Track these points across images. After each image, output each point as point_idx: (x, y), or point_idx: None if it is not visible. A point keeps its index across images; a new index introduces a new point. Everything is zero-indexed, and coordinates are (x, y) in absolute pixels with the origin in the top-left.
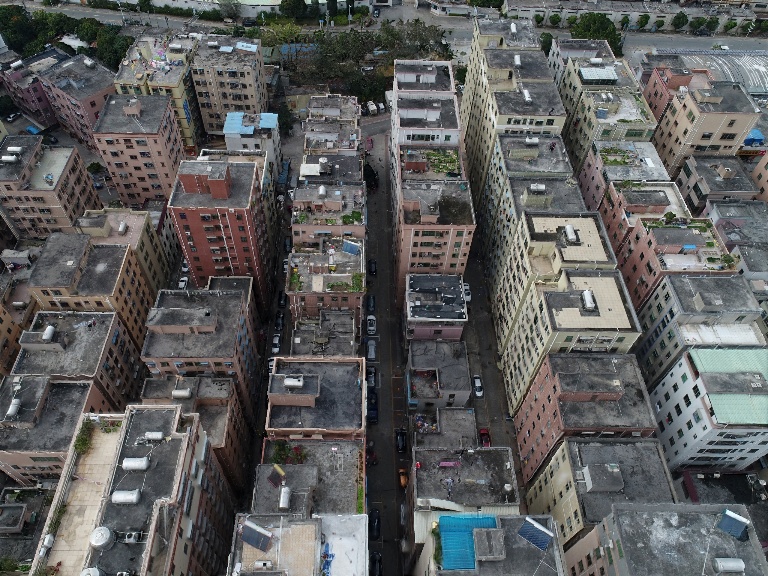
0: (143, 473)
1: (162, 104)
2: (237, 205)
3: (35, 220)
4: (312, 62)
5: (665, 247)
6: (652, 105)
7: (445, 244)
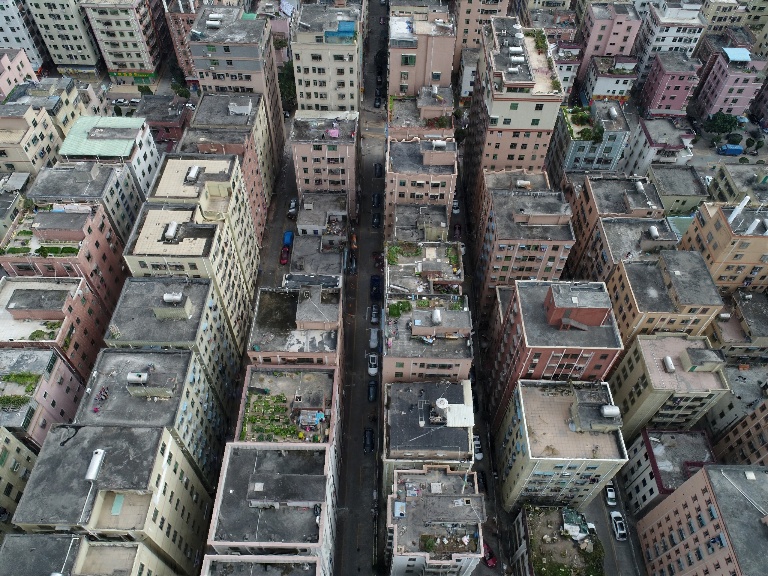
0: None
1: (748, 561)
2: (531, 293)
3: None
4: None
5: None
6: None
7: None
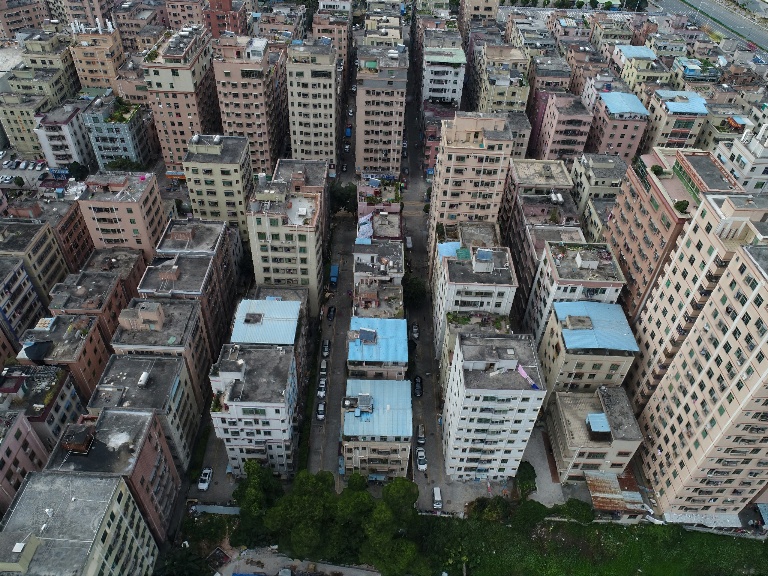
0: (190, 34)
1: None
2: None
3: (133, 40)
4: (285, 1)
5: (428, 24)
6: (461, 7)
7: (334, 39)
